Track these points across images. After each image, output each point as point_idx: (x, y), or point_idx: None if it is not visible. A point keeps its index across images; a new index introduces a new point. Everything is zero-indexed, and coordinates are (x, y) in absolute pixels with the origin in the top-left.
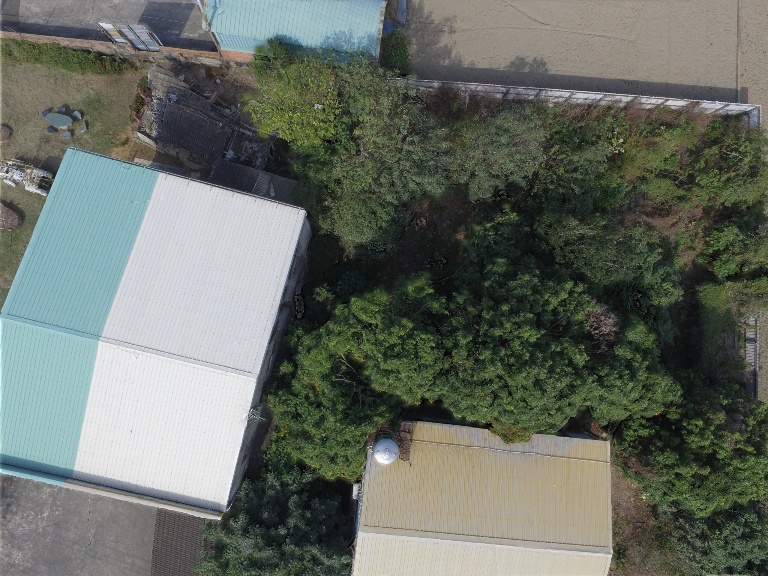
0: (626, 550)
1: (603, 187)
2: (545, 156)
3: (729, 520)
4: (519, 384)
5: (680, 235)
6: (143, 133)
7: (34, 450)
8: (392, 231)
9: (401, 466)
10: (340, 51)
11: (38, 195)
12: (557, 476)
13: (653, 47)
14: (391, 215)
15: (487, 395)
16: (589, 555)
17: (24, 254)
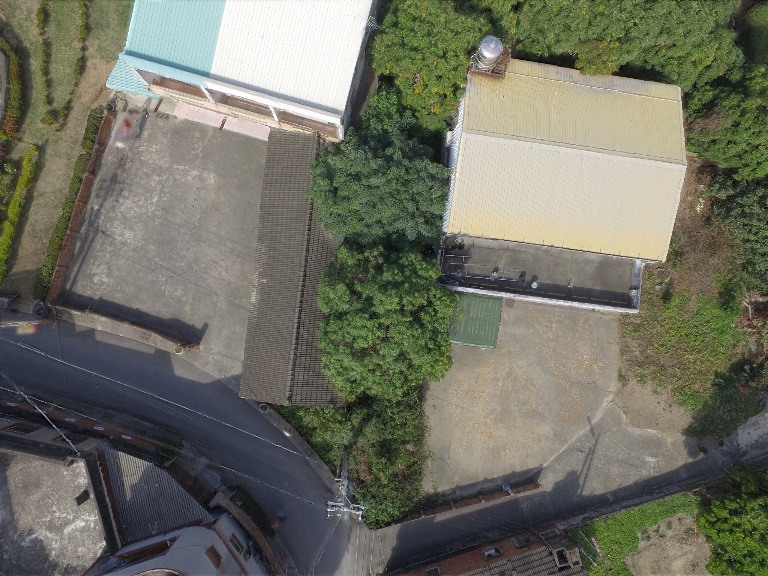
0: (682, 255)
1: None
2: None
3: None
4: None
5: None
6: None
7: (176, 53)
8: None
9: (495, 96)
10: None
11: None
12: None
13: None
14: None
15: None
16: (666, 166)
17: None
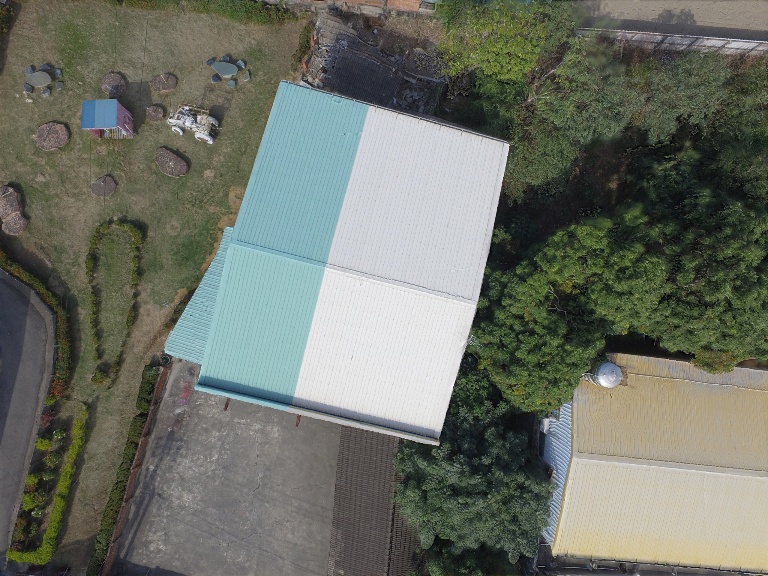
0: None
1: (757, 136)
2: (708, 102)
3: None
4: (748, 306)
5: None
6: (306, 82)
7: (256, 377)
8: (570, 172)
9: (602, 397)
10: None
11: (204, 143)
12: (751, 409)
13: None
14: (576, 154)
15: (716, 317)
16: None
17: (248, 183)
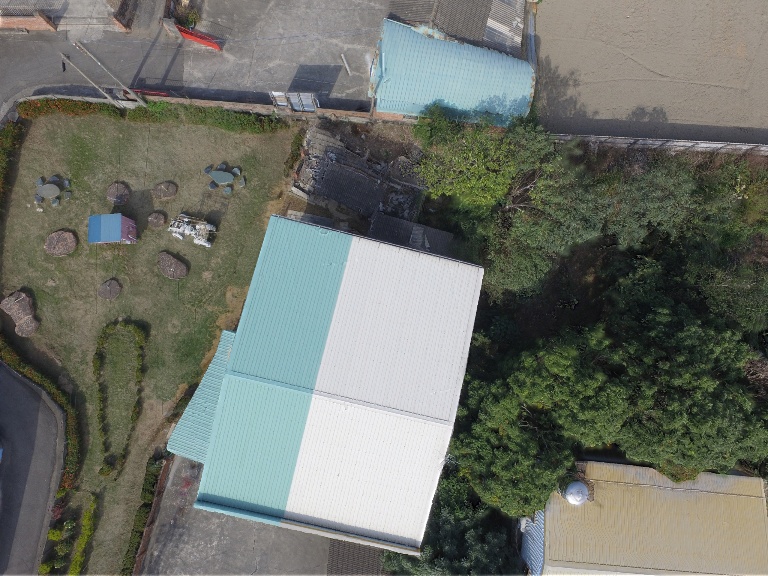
0: None
1: (726, 231)
2: (677, 205)
3: None
4: (703, 432)
5: None
6: (298, 187)
7: (250, 493)
8: (545, 280)
9: None
10: (492, 113)
11: (202, 246)
12: (715, 511)
13: (766, 95)
14: (549, 267)
15: (673, 442)
16: None
17: None
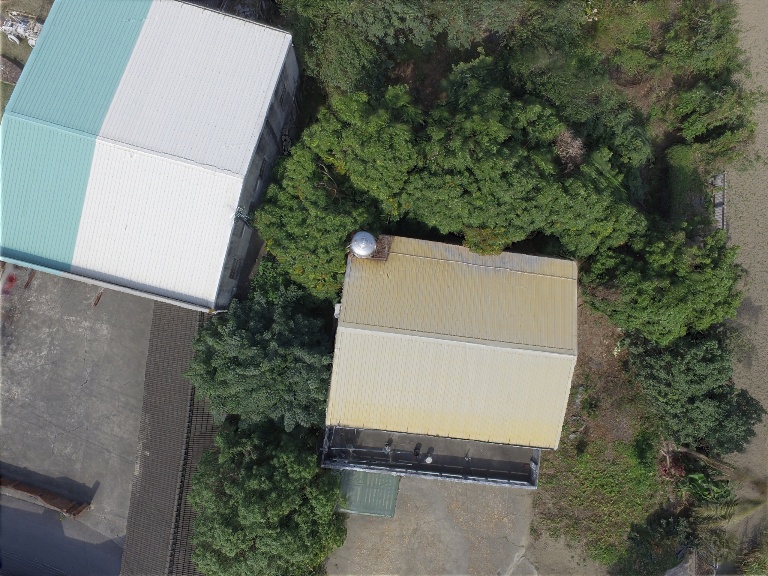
0: (598, 402)
1: (578, 55)
2: (521, 18)
3: (691, 348)
4: (487, 176)
5: (652, 106)
6: None
7: (34, 244)
8: (375, 76)
9: (379, 277)
10: None
11: None
12: None
13: None
14: (373, 55)
15: (457, 186)
16: (554, 357)
17: None
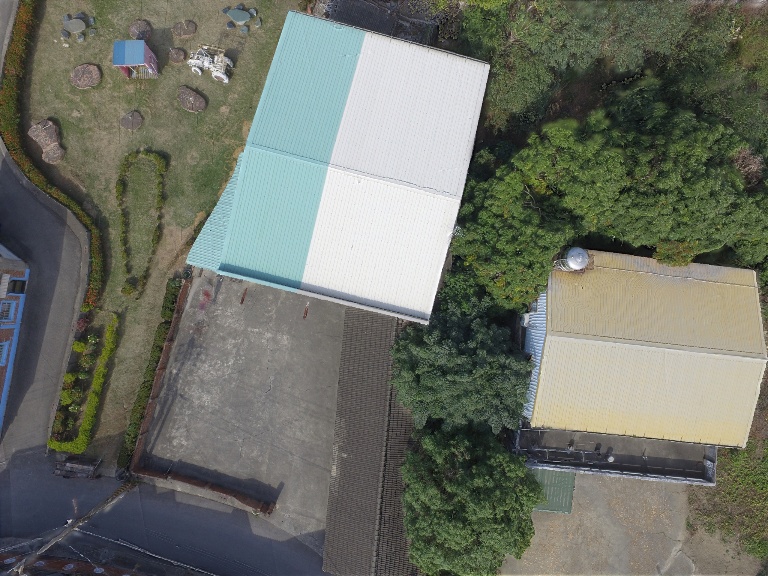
0: None
1: (722, 72)
2: (674, 39)
3: None
4: (697, 194)
5: None
6: None
7: (269, 264)
8: (547, 99)
9: (575, 288)
10: None
11: (220, 82)
12: None
13: None
14: (551, 80)
15: (669, 204)
16: (747, 360)
17: None
